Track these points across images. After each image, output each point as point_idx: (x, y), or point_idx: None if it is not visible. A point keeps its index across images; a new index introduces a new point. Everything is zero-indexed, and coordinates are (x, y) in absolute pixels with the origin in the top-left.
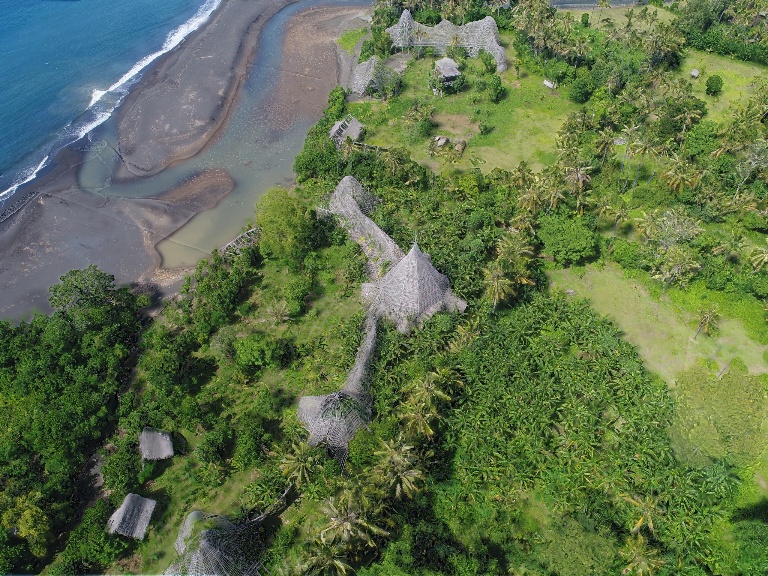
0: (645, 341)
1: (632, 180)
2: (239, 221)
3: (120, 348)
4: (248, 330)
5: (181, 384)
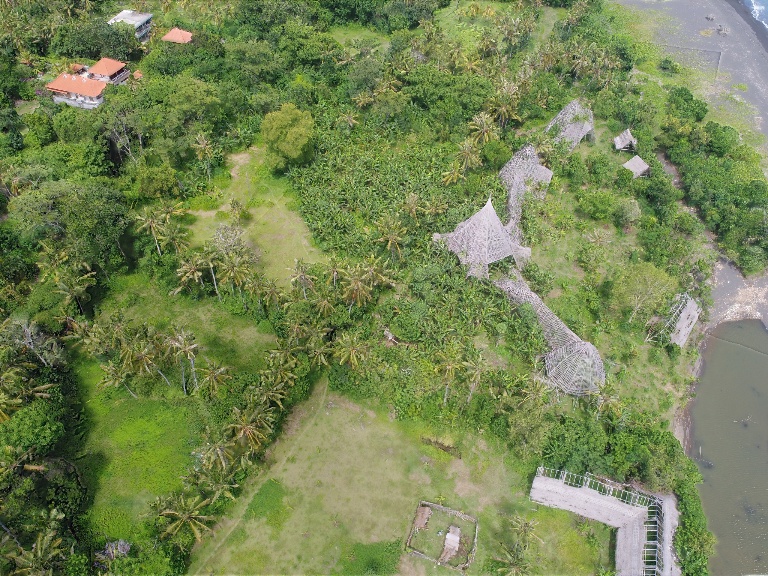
0: (282, 232)
1: (179, 401)
2: (718, 388)
3: (714, 215)
4: (622, 247)
5: (646, 197)
